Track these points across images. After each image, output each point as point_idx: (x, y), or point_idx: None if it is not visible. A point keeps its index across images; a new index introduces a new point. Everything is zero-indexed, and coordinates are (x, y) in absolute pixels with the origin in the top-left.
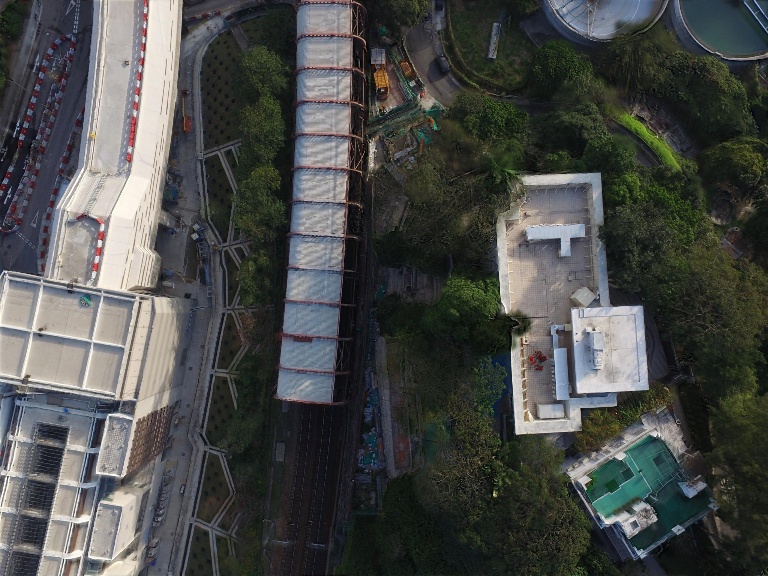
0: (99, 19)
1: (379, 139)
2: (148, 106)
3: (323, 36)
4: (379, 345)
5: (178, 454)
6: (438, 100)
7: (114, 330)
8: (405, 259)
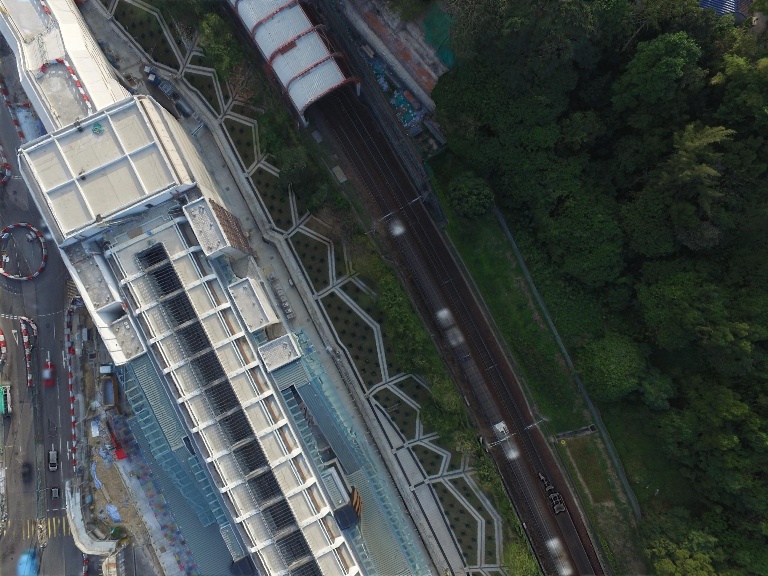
0: None
1: None
2: None
3: None
4: (351, 16)
5: (268, 261)
6: None
7: (137, 137)
8: None
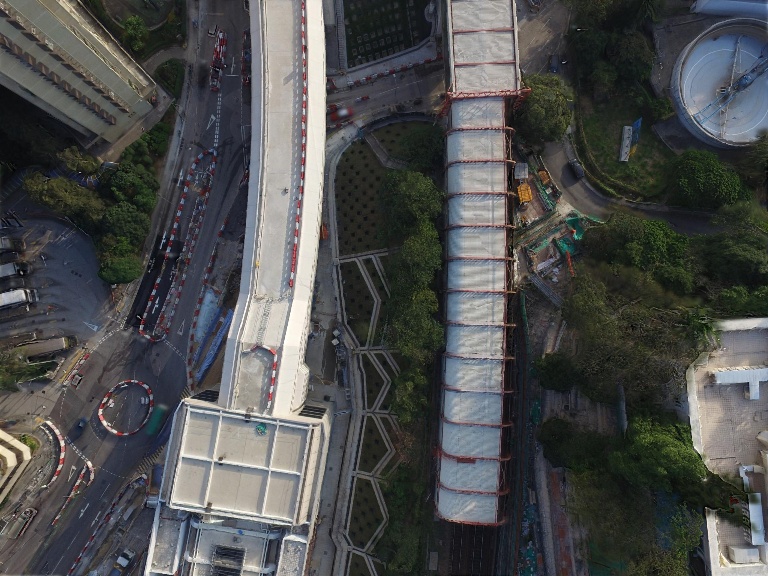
0: (260, 150)
1: (521, 250)
2: (306, 231)
3: (477, 161)
4: (538, 463)
5: (321, 553)
6: (573, 206)
7: (289, 457)
8: (571, 386)
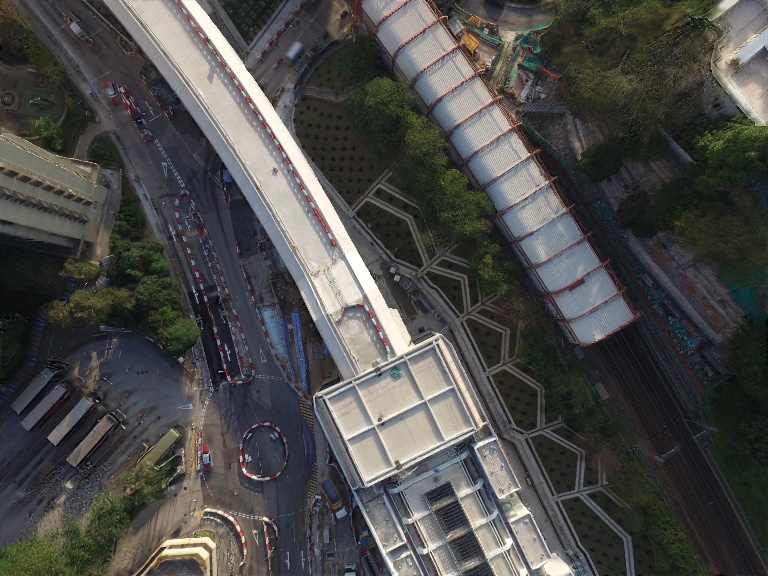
0: (230, 151)
1: (498, 92)
2: (315, 193)
3: (417, 36)
4: (633, 248)
5: None
6: (514, 30)
7: (434, 380)
8: (620, 161)
